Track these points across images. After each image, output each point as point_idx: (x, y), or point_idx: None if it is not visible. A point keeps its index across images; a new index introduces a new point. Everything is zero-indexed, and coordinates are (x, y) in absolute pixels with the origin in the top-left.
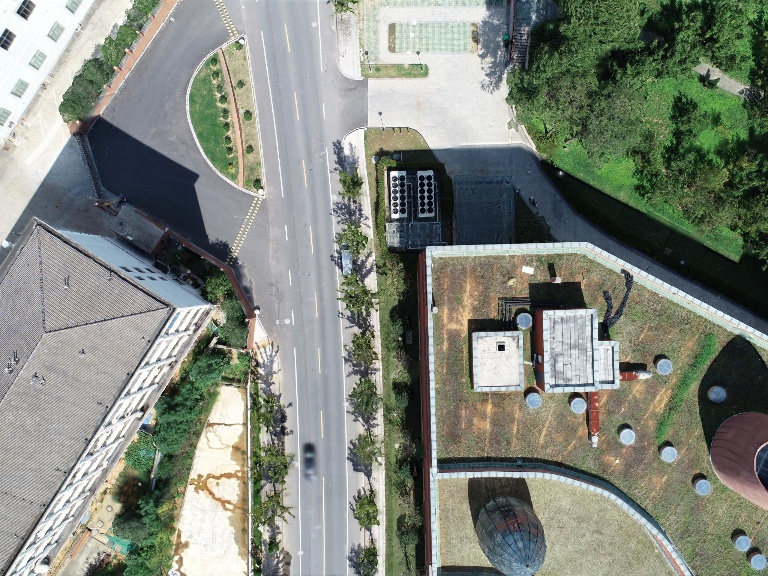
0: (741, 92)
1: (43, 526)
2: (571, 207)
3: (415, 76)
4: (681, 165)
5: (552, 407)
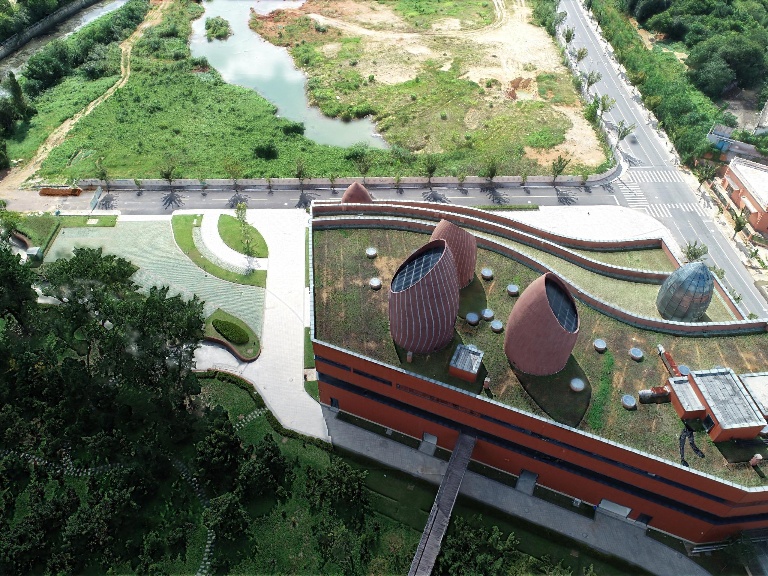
0: None
1: None
2: None
3: None
4: None
5: None
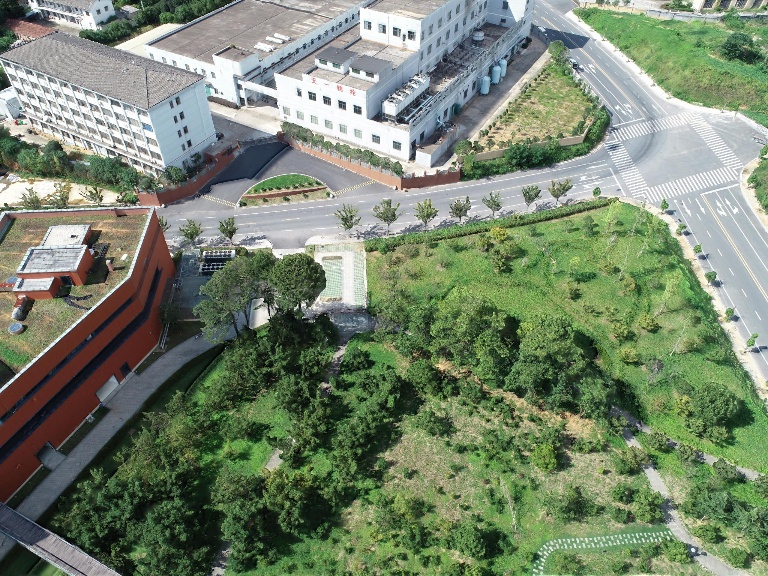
0: None
1: (63, 98)
2: None
3: None
4: None
5: None
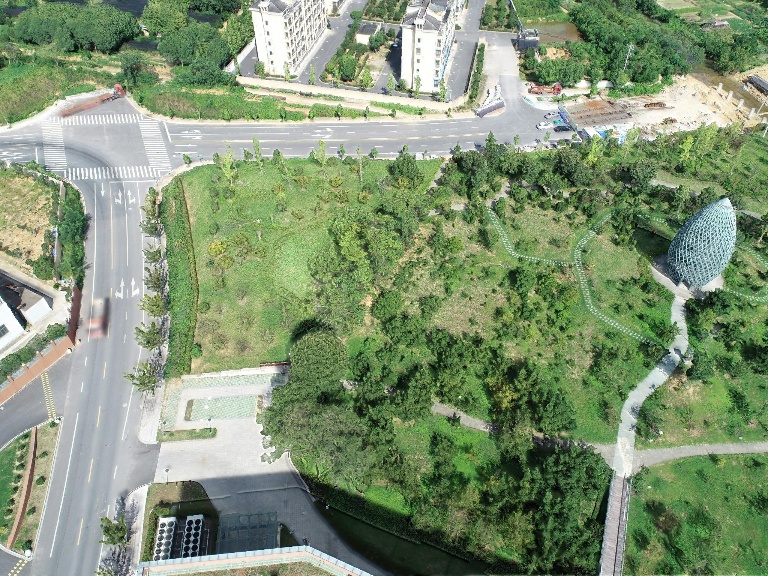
0: (485, 428)
1: None
2: (346, 545)
3: (204, 437)
4: (439, 490)
5: None
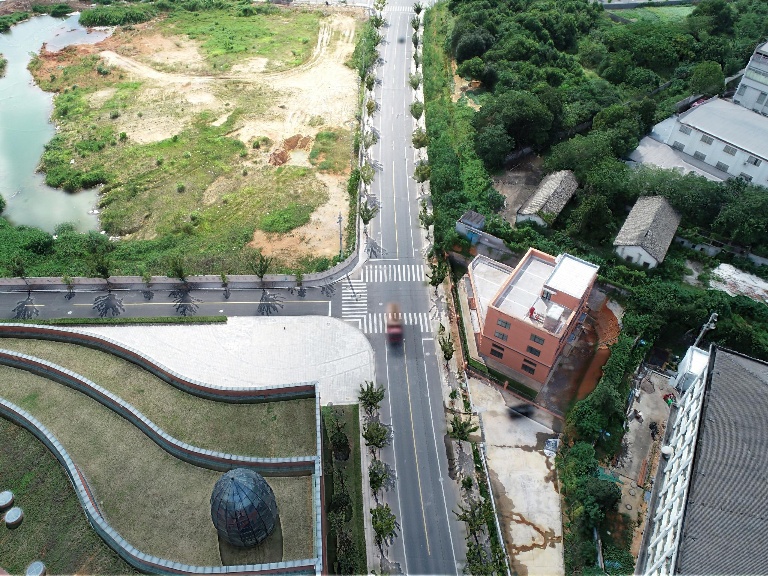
0: None
1: None
2: None
3: None
4: None
5: None
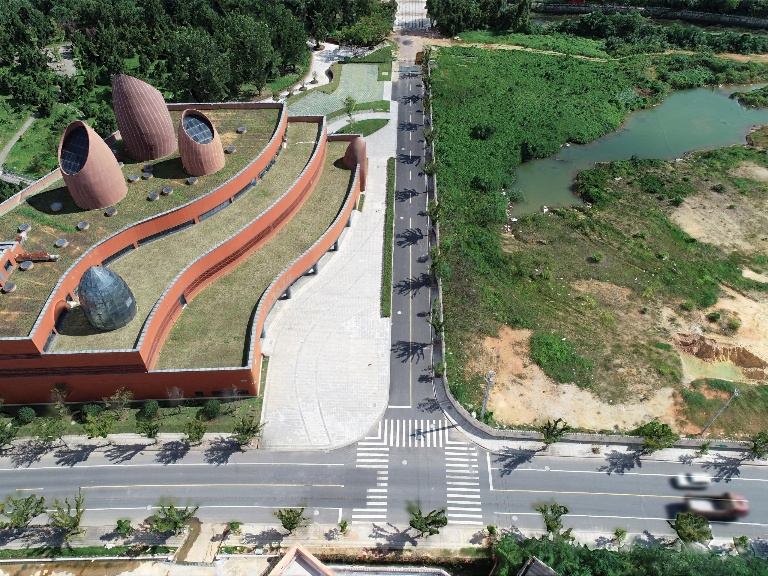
0: None
1: None
2: None
3: None
4: None
5: (22, 279)
